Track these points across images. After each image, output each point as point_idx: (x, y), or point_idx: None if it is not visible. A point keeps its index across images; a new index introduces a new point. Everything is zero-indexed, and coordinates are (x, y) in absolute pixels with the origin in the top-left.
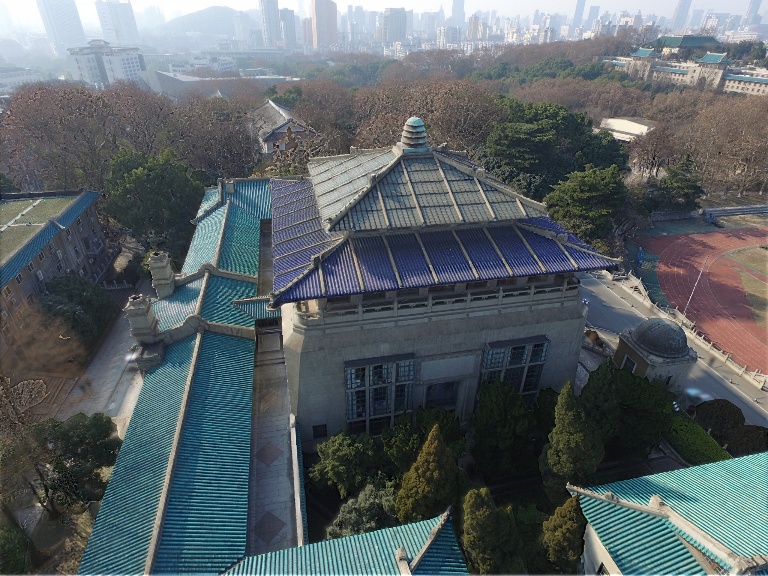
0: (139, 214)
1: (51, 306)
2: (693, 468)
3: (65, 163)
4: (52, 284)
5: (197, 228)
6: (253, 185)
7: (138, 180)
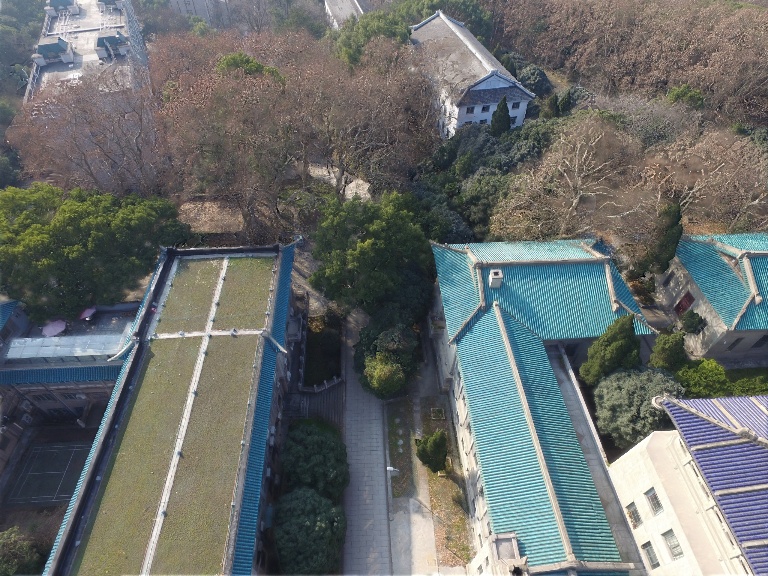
0: (358, 297)
1: (308, 527)
2: None
3: (218, 146)
4: (291, 461)
5: (463, 362)
6: (524, 273)
7: (363, 256)
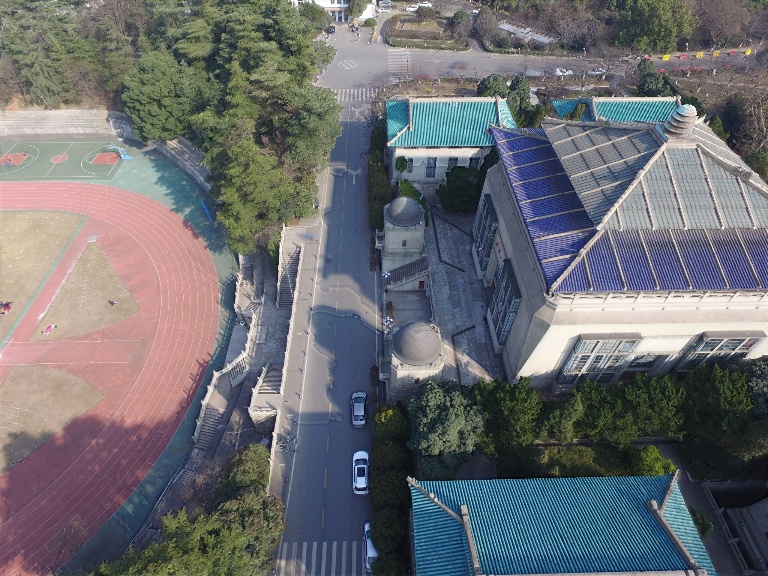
0: None
1: None
2: (467, 144)
3: None
4: None
5: None
6: None
7: None
